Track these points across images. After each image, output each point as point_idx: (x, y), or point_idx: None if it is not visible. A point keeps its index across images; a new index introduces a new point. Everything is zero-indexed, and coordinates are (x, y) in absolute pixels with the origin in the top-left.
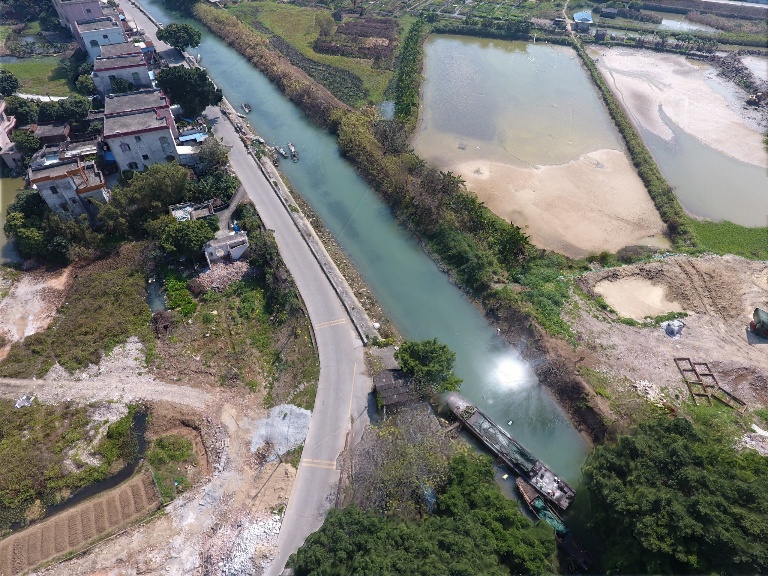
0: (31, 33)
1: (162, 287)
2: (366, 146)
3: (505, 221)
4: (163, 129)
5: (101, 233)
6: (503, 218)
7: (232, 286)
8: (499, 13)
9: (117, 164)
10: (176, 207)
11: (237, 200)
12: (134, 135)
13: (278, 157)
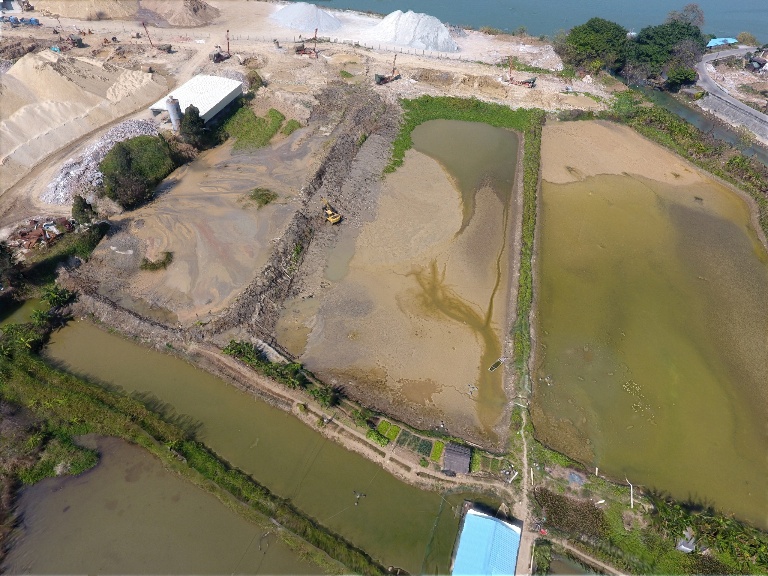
0: None
1: None
2: None
3: None
4: None
5: None
6: None
7: None
8: None
9: None
10: None
11: None
12: None
13: None
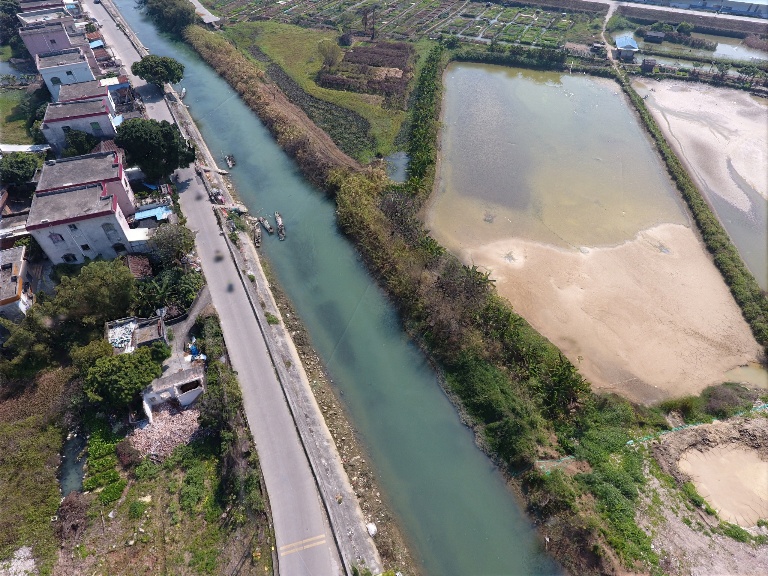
0: (0, 60)
1: (83, 448)
2: (369, 225)
3: (548, 341)
4: (106, 215)
5: (19, 354)
6: (544, 333)
7: (176, 454)
8: (528, 36)
9: (48, 257)
10: (115, 323)
11: (198, 308)
12: (67, 223)
13: (261, 233)
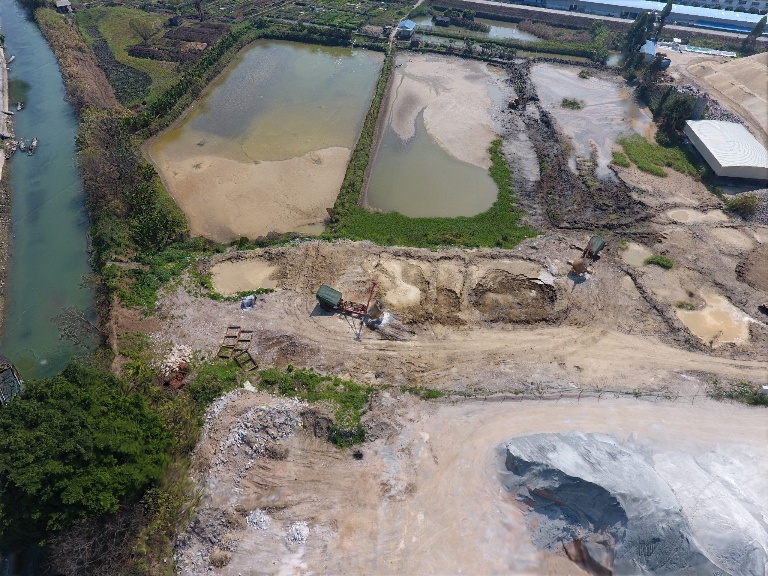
0: None
1: None
2: (87, 141)
3: (178, 209)
4: None
5: None
6: (185, 207)
7: None
8: (338, 20)
9: None
10: None
11: None
12: None
13: (16, 150)
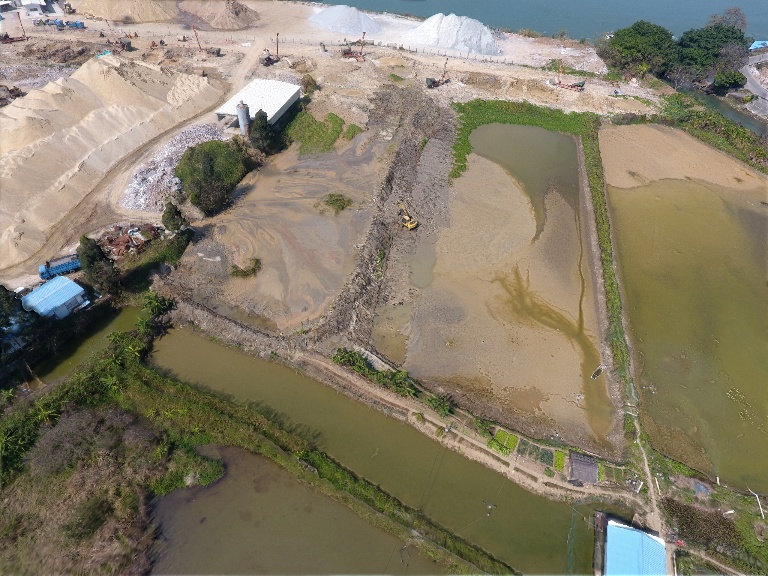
0: None
1: None
2: None
3: None
4: None
5: None
6: None
7: None
8: None
9: None
10: None
11: None
12: None
13: None
